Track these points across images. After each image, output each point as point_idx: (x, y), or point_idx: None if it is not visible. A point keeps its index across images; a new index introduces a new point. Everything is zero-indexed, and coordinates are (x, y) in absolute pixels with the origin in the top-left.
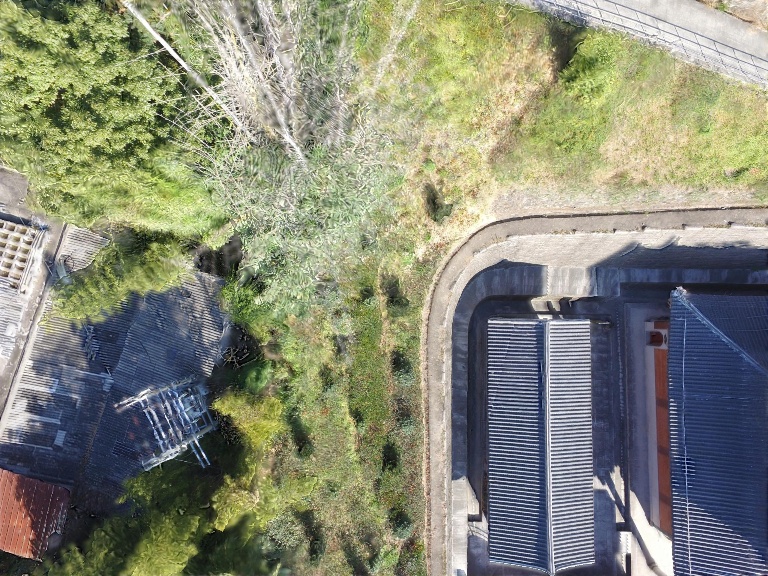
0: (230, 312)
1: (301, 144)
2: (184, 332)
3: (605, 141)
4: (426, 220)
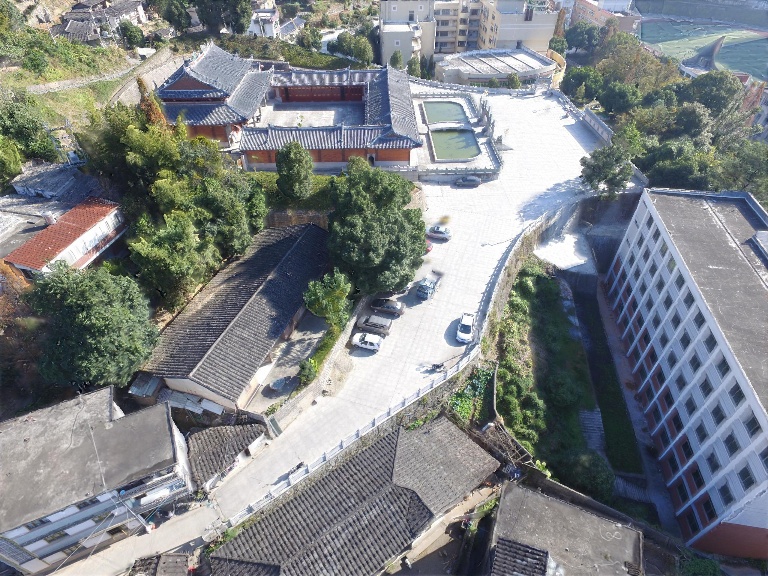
0: (44, 152)
1: None
2: (47, 173)
3: None
4: None
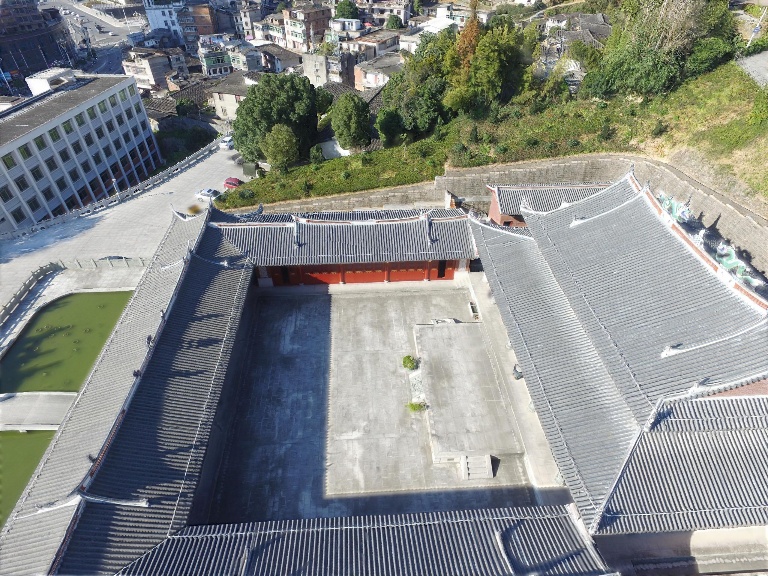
0: None
1: (666, 7)
2: None
3: (740, 150)
4: (650, 136)
